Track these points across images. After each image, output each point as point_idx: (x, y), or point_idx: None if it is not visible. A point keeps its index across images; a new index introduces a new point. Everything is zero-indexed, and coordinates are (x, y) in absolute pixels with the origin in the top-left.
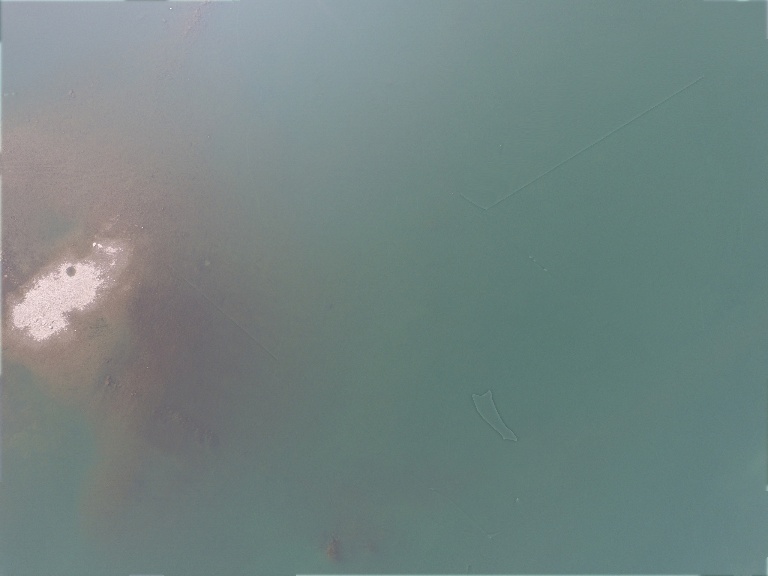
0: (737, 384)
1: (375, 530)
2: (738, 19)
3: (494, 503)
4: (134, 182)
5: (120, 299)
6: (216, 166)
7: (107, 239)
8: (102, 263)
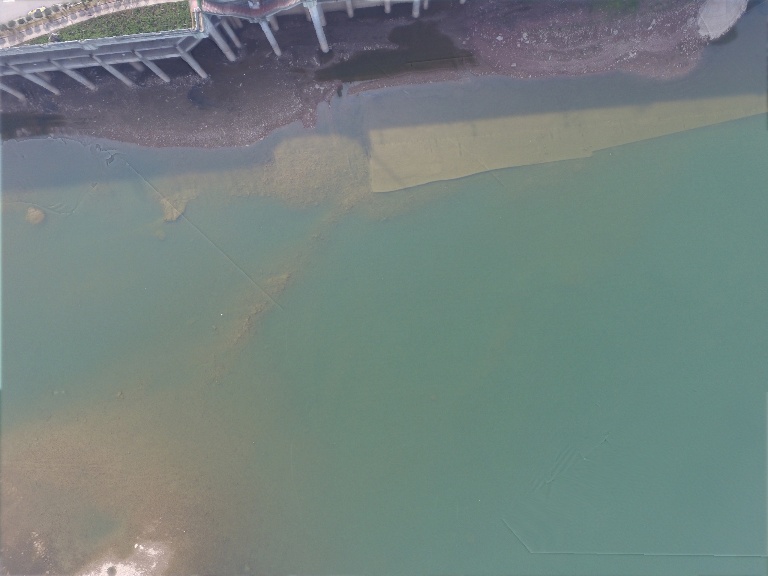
0: None
1: None
2: None
3: None
4: (178, 485)
5: None
6: (260, 472)
7: (149, 541)
8: (143, 565)
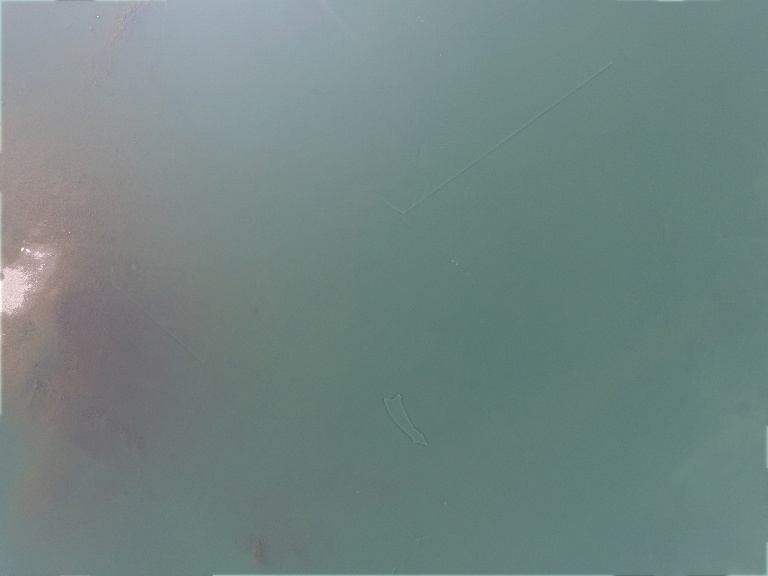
0: (660, 388)
1: (301, 533)
2: (623, 24)
3: (422, 506)
4: (62, 188)
5: (48, 303)
6: (142, 172)
7: (35, 244)
8: (30, 268)
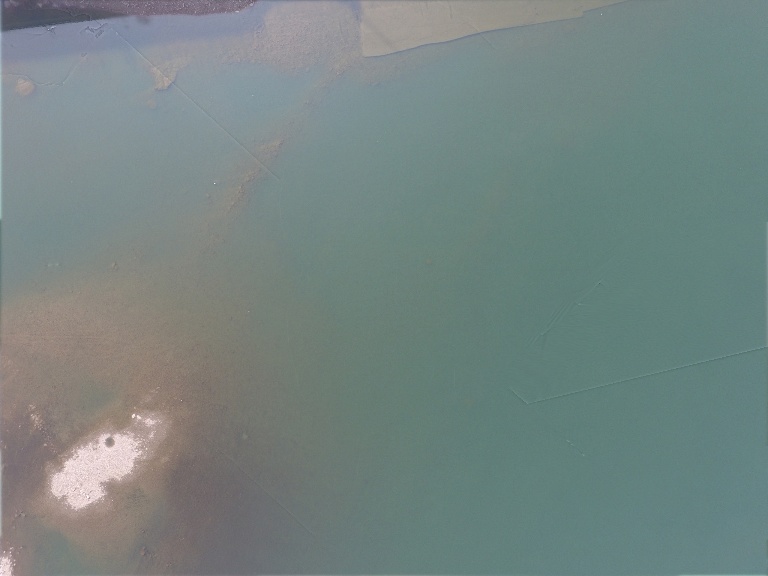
0: None
1: None
2: None
3: None
4: (174, 355)
5: (158, 470)
6: (256, 340)
7: (146, 411)
8: (141, 435)
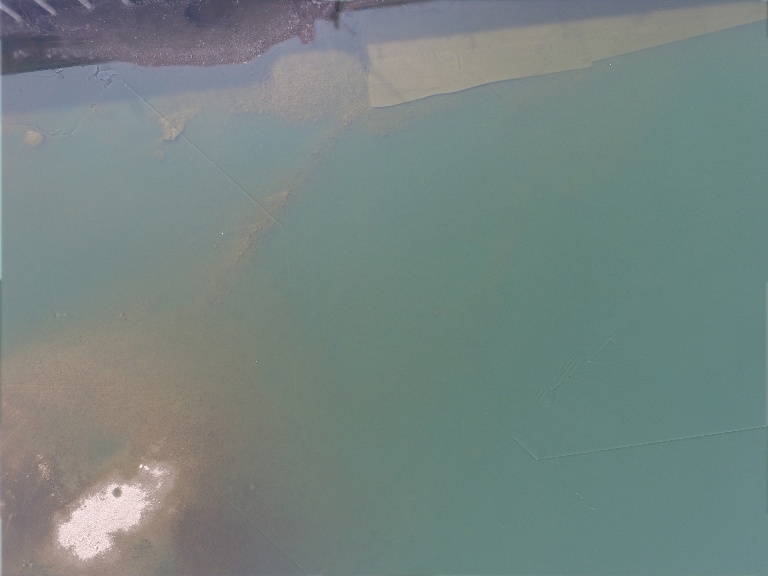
0: None
1: None
2: None
3: None
4: (182, 405)
5: (165, 521)
6: (263, 391)
7: (154, 461)
8: (148, 485)
